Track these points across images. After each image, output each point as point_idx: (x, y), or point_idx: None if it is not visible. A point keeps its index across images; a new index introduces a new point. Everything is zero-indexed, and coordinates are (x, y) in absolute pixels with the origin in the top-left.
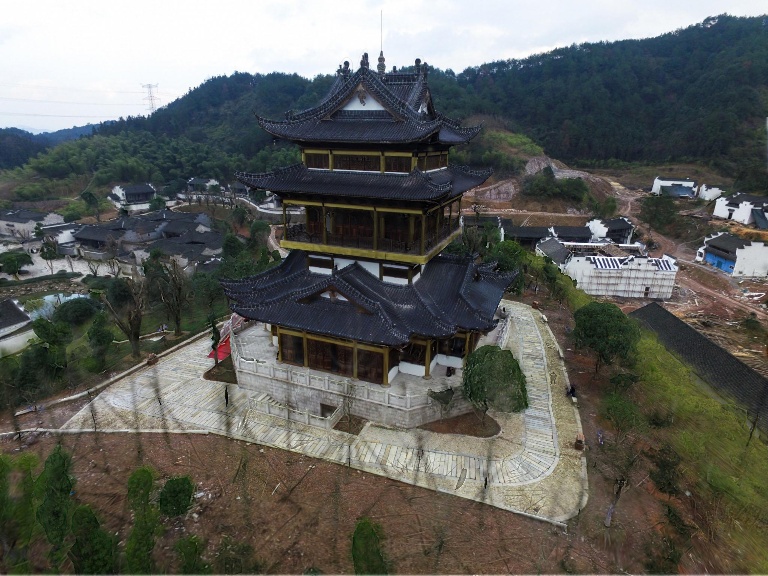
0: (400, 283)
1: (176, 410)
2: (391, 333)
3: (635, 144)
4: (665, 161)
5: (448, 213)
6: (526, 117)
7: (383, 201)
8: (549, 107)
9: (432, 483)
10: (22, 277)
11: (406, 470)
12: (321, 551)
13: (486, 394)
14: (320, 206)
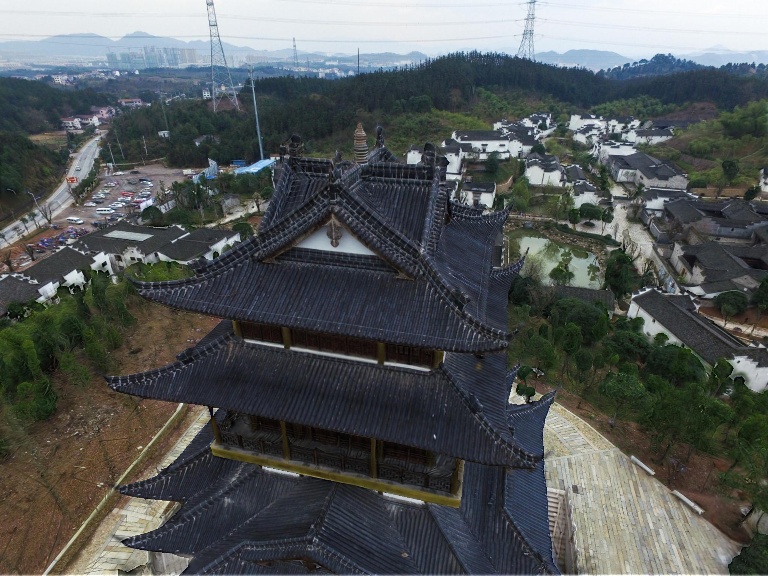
0: None
1: None
2: None
3: None
4: None
5: None
6: None
7: None
8: None
9: None
10: (580, 228)
11: (87, 571)
12: (0, 510)
13: None
14: None
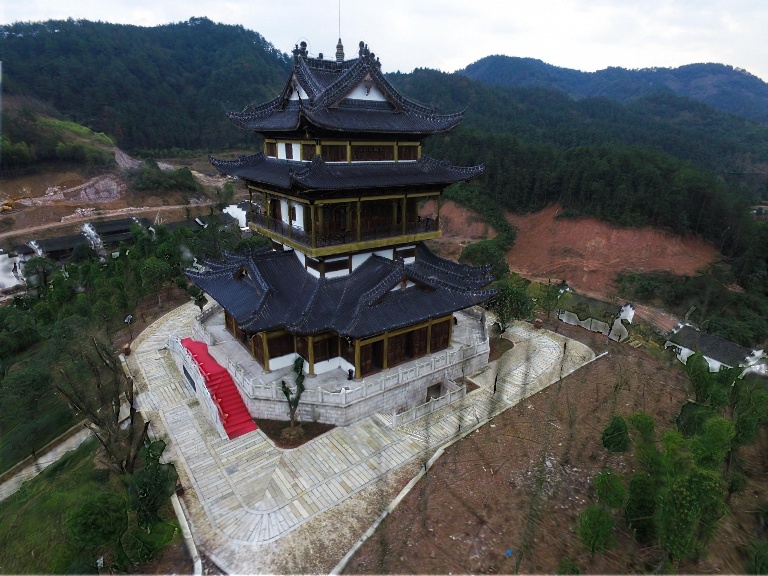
0: (409, 262)
1: (347, 480)
2: (468, 296)
3: (189, 133)
4: (225, 148)
5: (48, 224)
6: (47, 100)
7: (412, 187)
8: (74, 90)
9: (550, 378)
10: None
11: (533, 382)
12: None
13: (530, 310)
14: (356, 201)
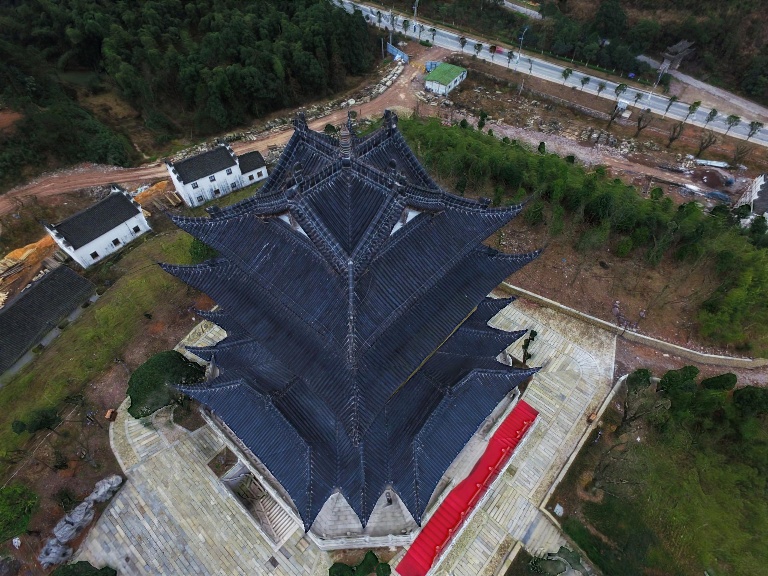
0: None
1: (540, 332)
2: None
3: None
4: None
5: None
6: None
7: None
8: None
9: None
10: None
11: None
12: None
13: None
14: None
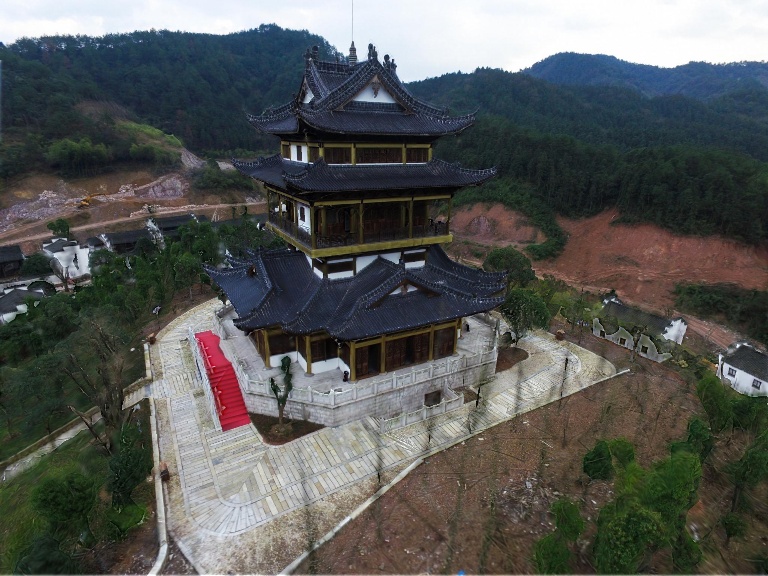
0: (418, 266)
1: (323, 481)
2: (474, 302)
3: (252, 135)
4: None
5: (118, 219)
6: (129, 105)
7: (419, 190)
8: (152, 95)
9: (559, 393)
10: None
11: (539, 396)
12: None
13: (544, 321)
14: (358, 204)
